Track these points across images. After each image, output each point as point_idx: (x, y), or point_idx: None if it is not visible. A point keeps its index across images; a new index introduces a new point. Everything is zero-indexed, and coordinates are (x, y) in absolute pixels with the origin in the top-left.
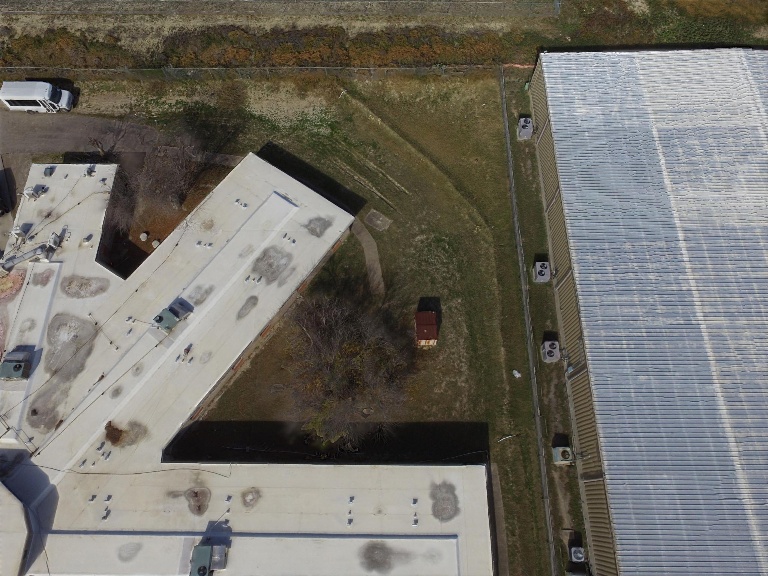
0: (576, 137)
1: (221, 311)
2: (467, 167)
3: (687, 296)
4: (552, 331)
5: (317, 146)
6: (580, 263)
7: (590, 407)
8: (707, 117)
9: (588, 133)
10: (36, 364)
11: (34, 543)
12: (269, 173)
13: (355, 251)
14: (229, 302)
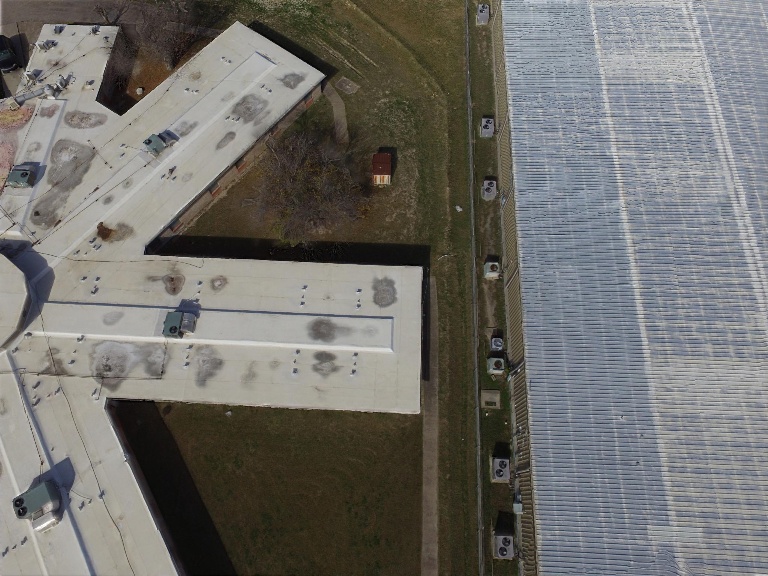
0: (522, 10)
1: (203, 142)
2: (430, 46)
3: (605, 134)
4: (492, 176)
5: (298, 25)
6: (515, 107)
7: (513, 217)
8: None
9: (533, 8)
10: (40, 177)
11: (32, 309)
12: (252, 37)
13: (325, 109)
14: (210, 136)
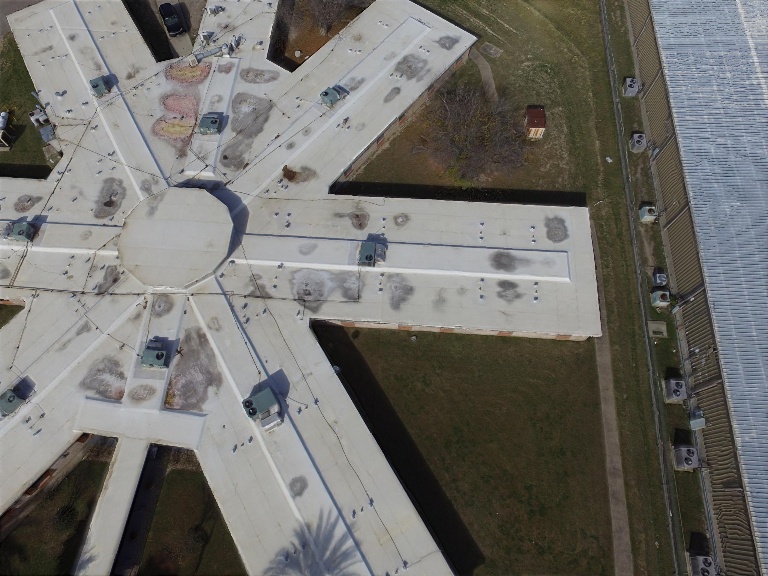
0: None
1: (371, 96)
2: (565, 15)
3: (757, 88)
4: (639, 131)
5: None
6: (669, 63)
7: (677, 162)
8: None
9: None
10: (225, 125)
11: (233, 239)
12: (405, 4)
13: (472, 71)
14: (377, 90)
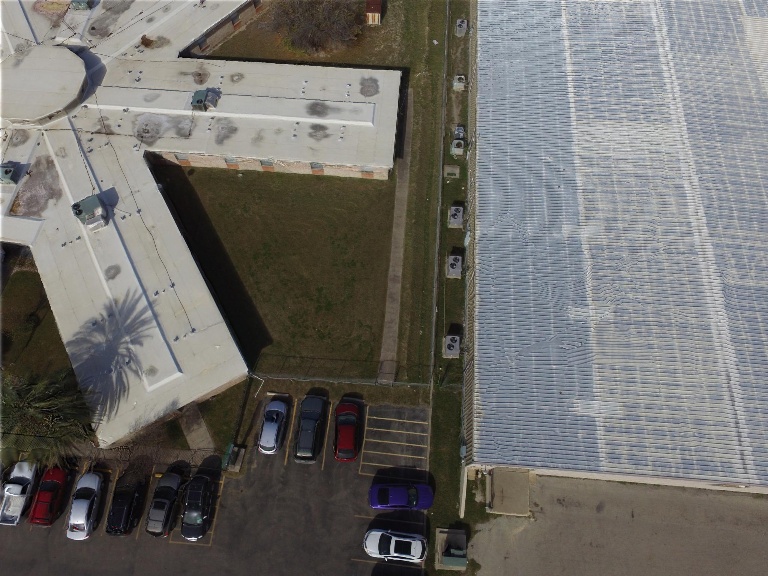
0: None
1: None
2: None
3: None
4: (465, 19)
5: None
6: None
7: None
8: None
9: None
10: (97, 4)
11: (88, 90)
12: None
13: None
14: None
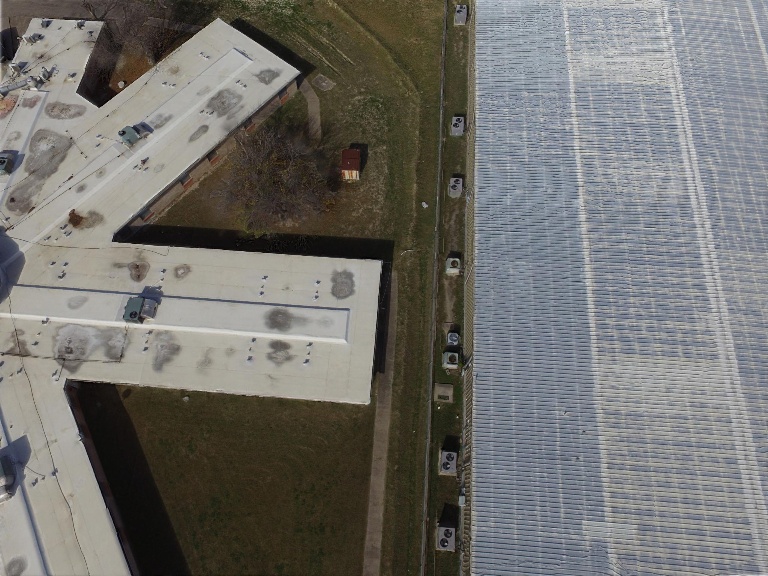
0: (495, 11)
1: (176, 135)
2: (407, 45)
3: (569, 134)
4: (460, 173)
5: (279, 23)
6: (481, 105)
7: None
8: (613, 1)
9: (506, 8)
10: (18, 165)
11: (1, 291)
12: (231, 34)
13: (300, 105)
14: (184, 128)
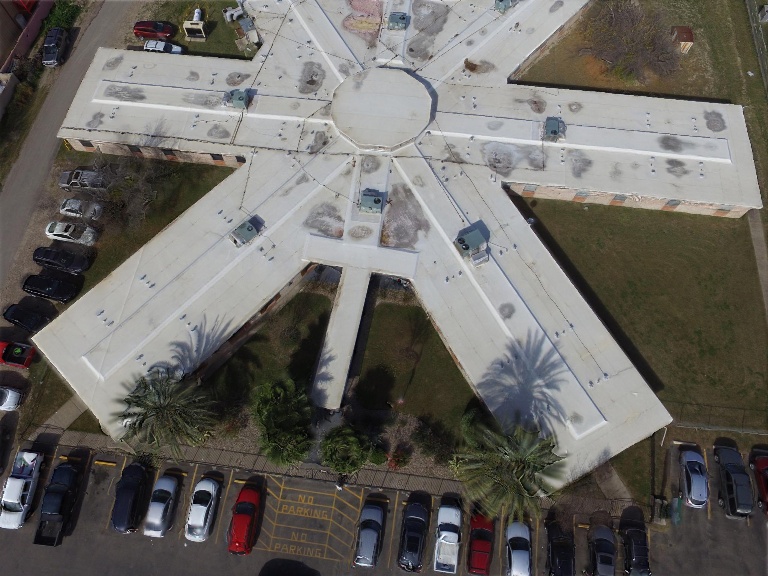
0: None
1: (537, 6)
2: None
3: None
4: None
5: None
6: None
7: None
8: None
9: None
10: (408, 24)
11: None
12: None
13: None
14: (542, 2)
